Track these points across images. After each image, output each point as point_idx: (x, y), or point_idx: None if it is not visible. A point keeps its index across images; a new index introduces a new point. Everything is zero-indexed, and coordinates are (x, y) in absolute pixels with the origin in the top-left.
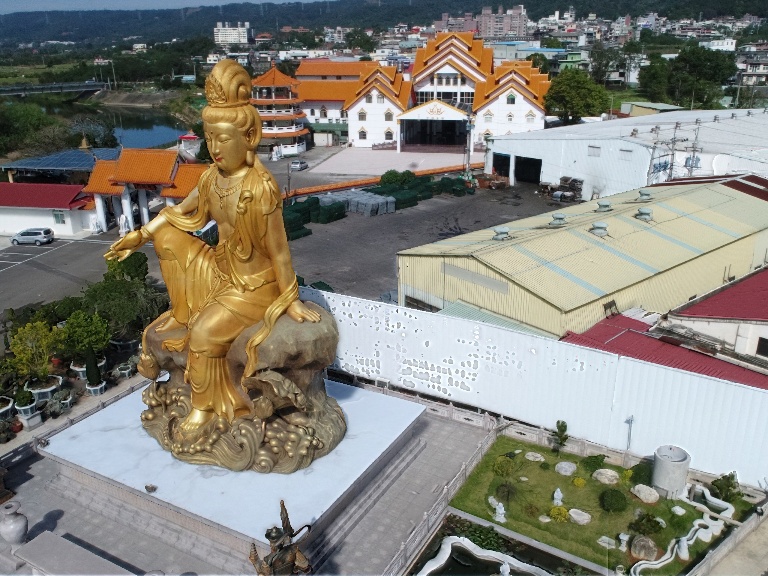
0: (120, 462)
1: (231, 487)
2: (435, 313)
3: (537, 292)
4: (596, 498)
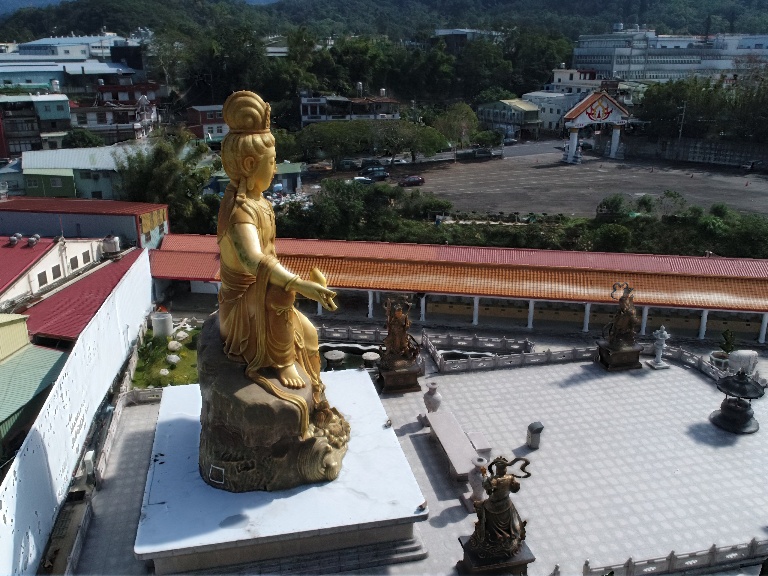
0: (385, 457)
1: (346, 404)
2: (72, 354)
3: (4, 321)
4: (192, 351)
